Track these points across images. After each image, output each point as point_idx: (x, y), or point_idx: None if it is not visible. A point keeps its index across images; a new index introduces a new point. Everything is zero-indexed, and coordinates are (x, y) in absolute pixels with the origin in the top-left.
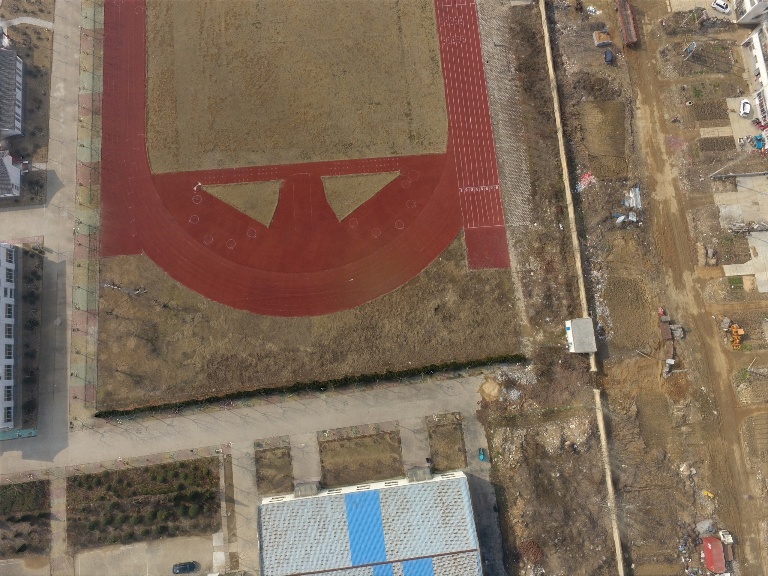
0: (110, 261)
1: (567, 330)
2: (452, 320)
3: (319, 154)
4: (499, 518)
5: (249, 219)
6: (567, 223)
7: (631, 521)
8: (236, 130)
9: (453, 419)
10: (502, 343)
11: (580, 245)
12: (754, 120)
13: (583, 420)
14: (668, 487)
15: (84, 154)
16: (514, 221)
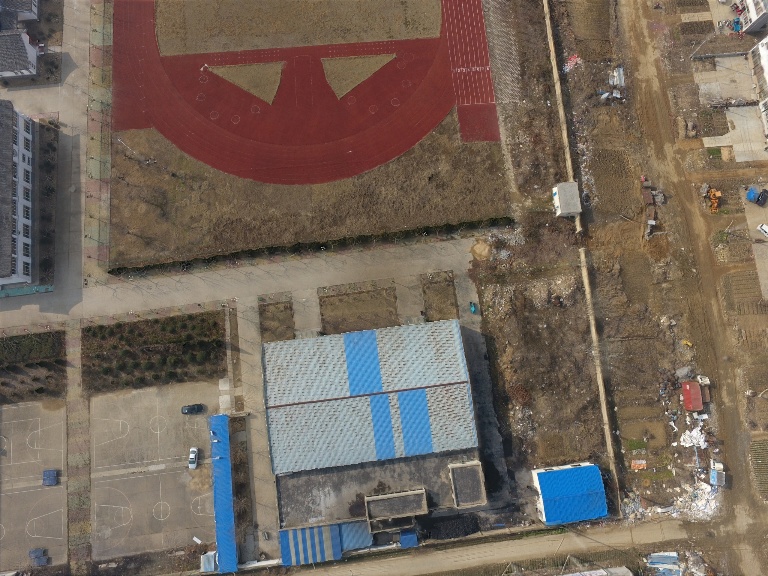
0: (122, 135)
1: (554, 196)
2: (445, 188)
3: (319, 38)
4: (489, 365)
5: (253, 97)
6: (554, 100)
7: (614, 369)
8: (240, 17)
9: (446, 277)
10: (492, 208)
11: (566, 118)
12: (732, 5)
13: (569, 277)
14: (649, 337)
15: (97, 38)
16: (504, 99)
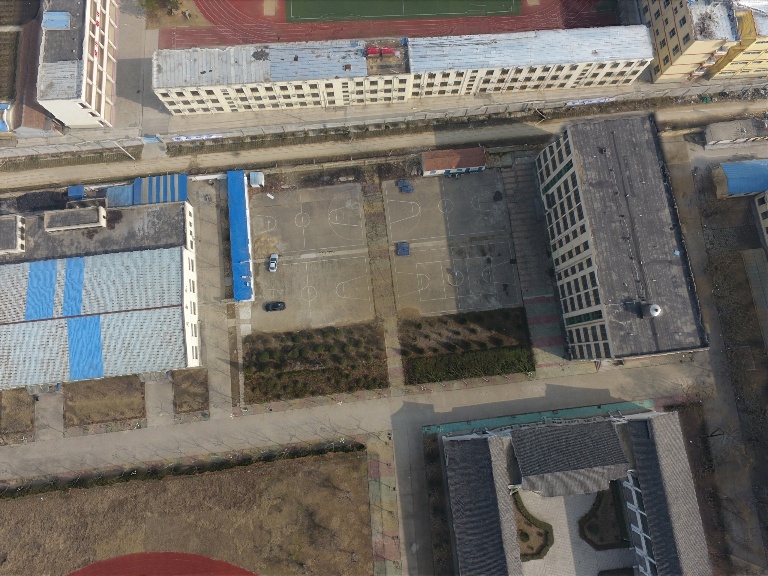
0: None
1: None
2: None
3: None
4: None
5: None
6: None
7: None
8: None
9: (7, 439)
10: None
11: None
12: None
13: None
14: None
15: None
16: None
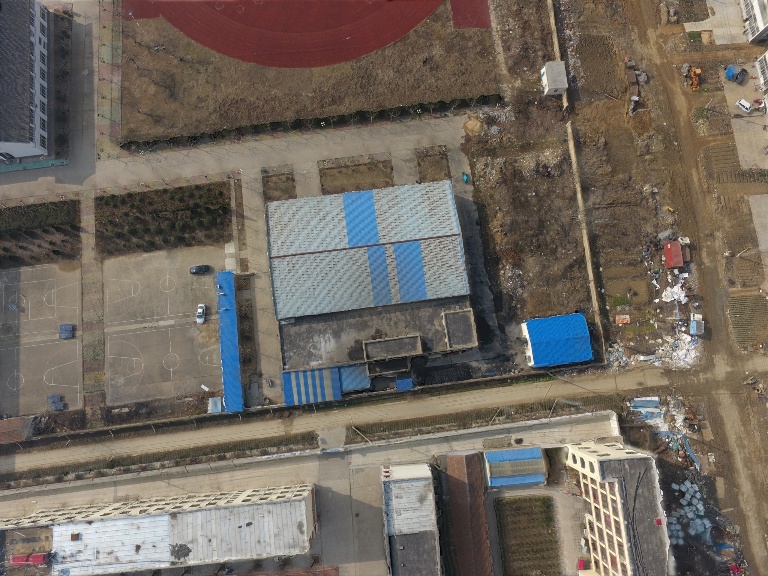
0: (132, 23)
1: (542, 77)
2: (439, 70)
3: None
4: (481, 230)
5: None
6: None
7: (599, 233)
8: None
9: (440, 151)
10: (484, 88)
11: (554, 5)
12: None
13: (556, 150)
14: (633, 204)
15: None
16: None
